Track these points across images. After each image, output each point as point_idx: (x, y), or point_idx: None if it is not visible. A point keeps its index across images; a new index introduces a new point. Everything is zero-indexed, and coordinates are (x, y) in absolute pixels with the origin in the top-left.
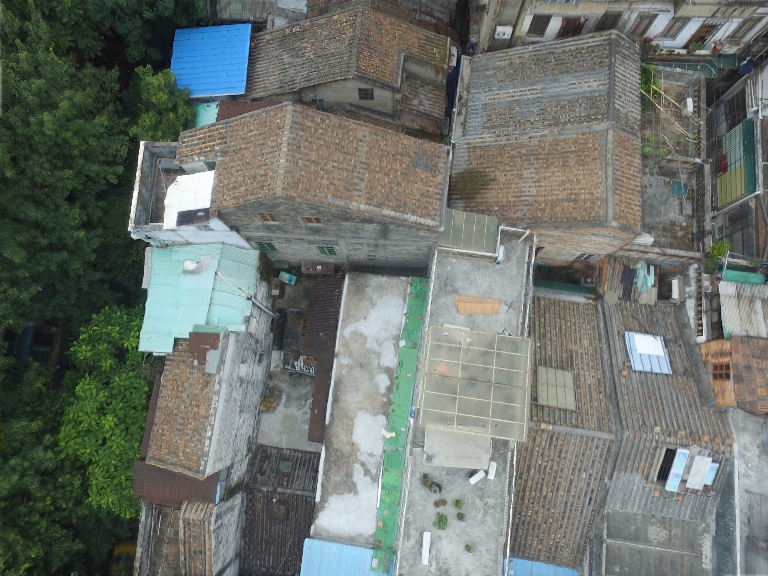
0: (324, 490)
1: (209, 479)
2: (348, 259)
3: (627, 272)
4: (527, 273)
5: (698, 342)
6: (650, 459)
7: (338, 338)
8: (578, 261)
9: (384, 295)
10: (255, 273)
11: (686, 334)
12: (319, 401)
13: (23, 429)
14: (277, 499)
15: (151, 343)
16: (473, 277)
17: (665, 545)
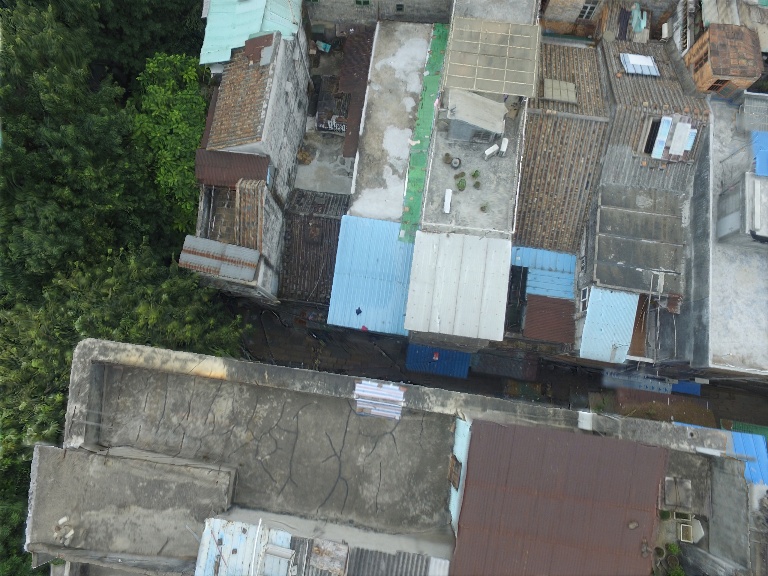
0: (358, 185)
1: (261, 162)
2: (378, 15)
3: (623, 14)
4: (536, 2)
5: (683, 56)
6: (639, 131)
7: (370, 70)
8: (580, 21)
9: (411, 37)
10: (299, 10)
11: (673, 56)
12: (353, 125)
13: (109, 91)
14: (313, 223)
15: (211, 56)
16: (489, 9)
17: (650, 210)
